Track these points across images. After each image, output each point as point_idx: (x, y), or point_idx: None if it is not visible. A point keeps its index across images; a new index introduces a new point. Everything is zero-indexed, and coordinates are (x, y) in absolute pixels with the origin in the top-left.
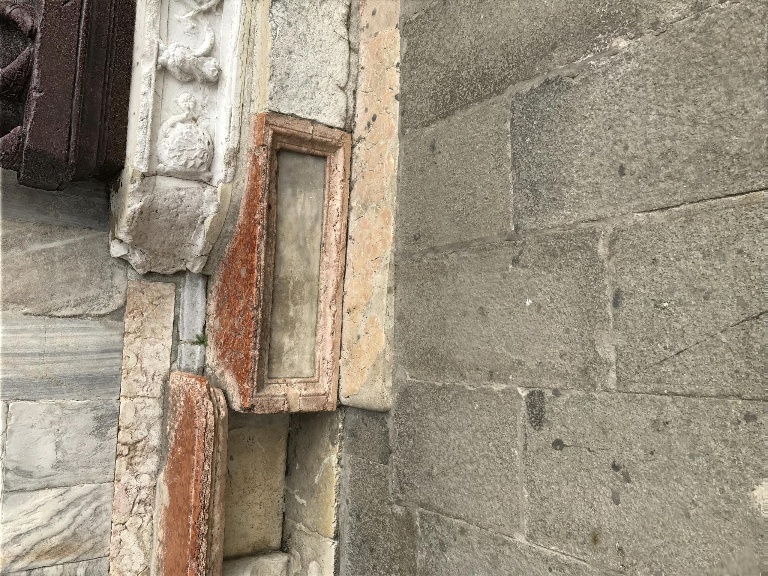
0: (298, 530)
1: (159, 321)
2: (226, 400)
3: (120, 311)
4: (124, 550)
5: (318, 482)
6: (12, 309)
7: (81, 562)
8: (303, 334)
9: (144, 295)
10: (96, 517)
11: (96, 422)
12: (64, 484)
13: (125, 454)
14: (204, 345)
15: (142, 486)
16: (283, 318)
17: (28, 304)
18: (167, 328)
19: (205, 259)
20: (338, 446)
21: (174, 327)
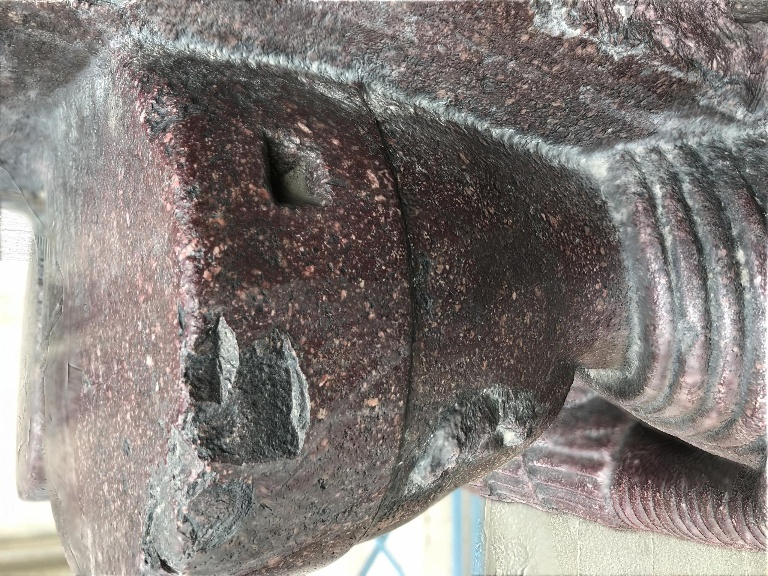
0: None
1: None
2: None
3: None
4: None
5: None
6: None
7: None
8: None
9: None
10: None
11: None
12: None
13: None
14: None
15: None
16: None
17: None
18: None
19: None
20: None
21: None
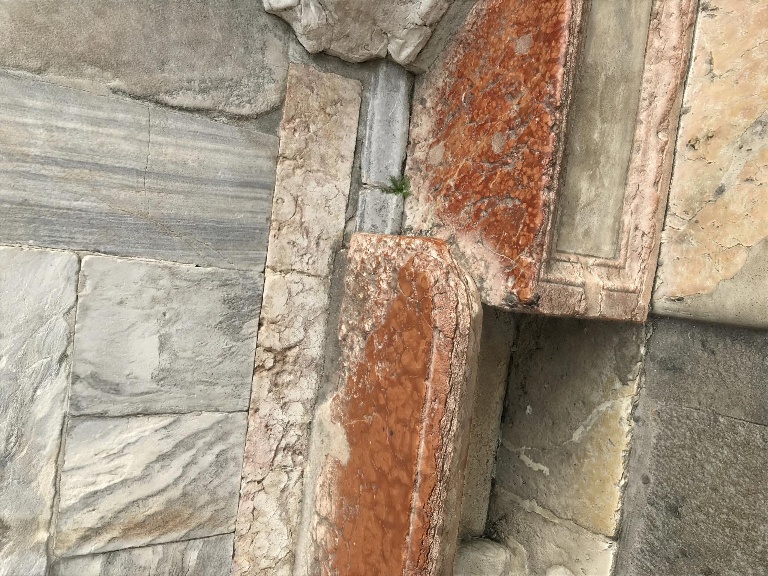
0: (526, 511)
1: (333, 144)
2: (475, 284)
3: (273, 116)
4: (258, 524)
5: (581, 440)
6: (92, 78)
7: (191, 541)
8: (609, 178)
9: (313, 94)
10: (218, 468)
11: (226, 307)
12: (170, 409)
13: (268, 366)
14: (403, 194)
15: (290, 422)
16: (584, 142)
17: (121, 73)
18: (344, 159)
19: (428, 34)
20: (636, 384)
21: (355, 159)
